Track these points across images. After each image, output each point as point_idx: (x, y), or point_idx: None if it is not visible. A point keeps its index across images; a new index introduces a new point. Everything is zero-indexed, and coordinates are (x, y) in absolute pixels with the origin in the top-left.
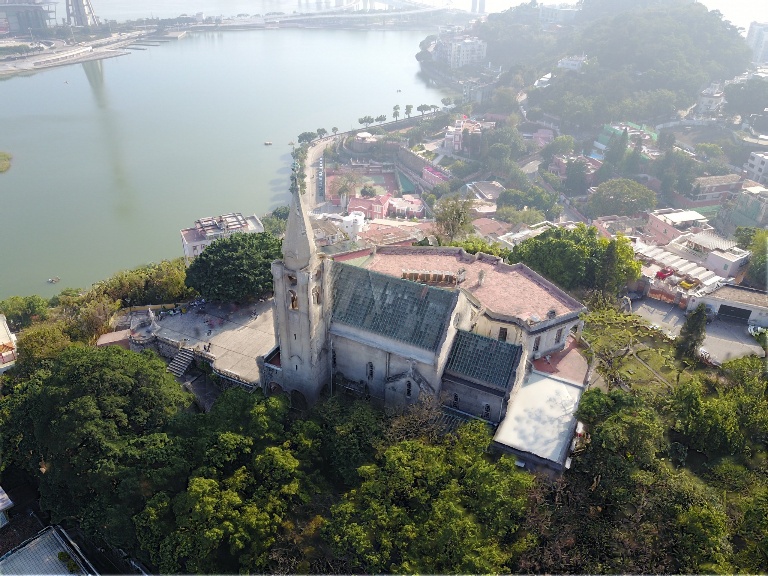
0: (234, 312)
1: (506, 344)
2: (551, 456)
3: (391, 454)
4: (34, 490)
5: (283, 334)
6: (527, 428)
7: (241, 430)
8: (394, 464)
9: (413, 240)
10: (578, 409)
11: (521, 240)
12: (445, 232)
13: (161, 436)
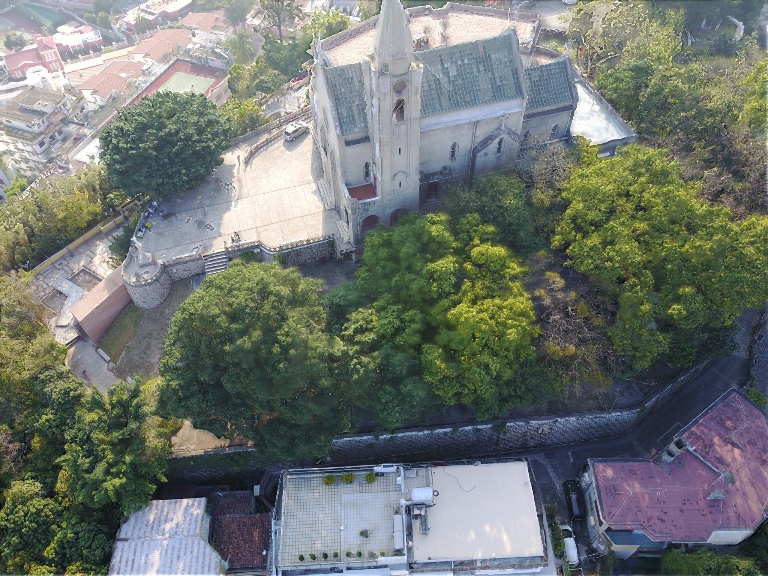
0: (202, 196)
1: (553, 64)
2: (620, 136)
3: (586, 185)
4: (179, 484)
5: (387, 155)
6: (584, 128)
7: (430, 257)
8: (598, 189)
9: (176, 62)
10: (613, 91)
11: (328, 4)
12: (267, 24)
13: (362, 312)
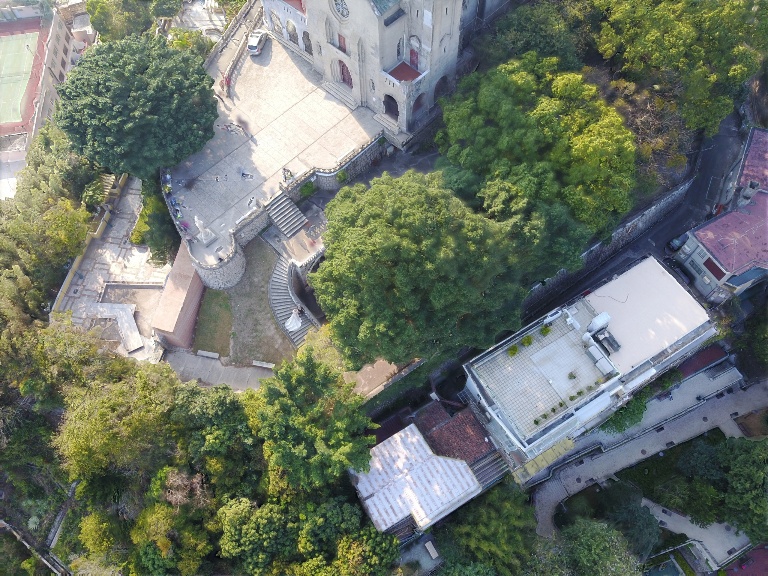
0: (210, 148)
1: None
2: None
3: None
4: None
5: (438, 20)
6: None
7: (521, 106)
8: None
9: None
10: None
11: None
12: None
13: (493, 184)
